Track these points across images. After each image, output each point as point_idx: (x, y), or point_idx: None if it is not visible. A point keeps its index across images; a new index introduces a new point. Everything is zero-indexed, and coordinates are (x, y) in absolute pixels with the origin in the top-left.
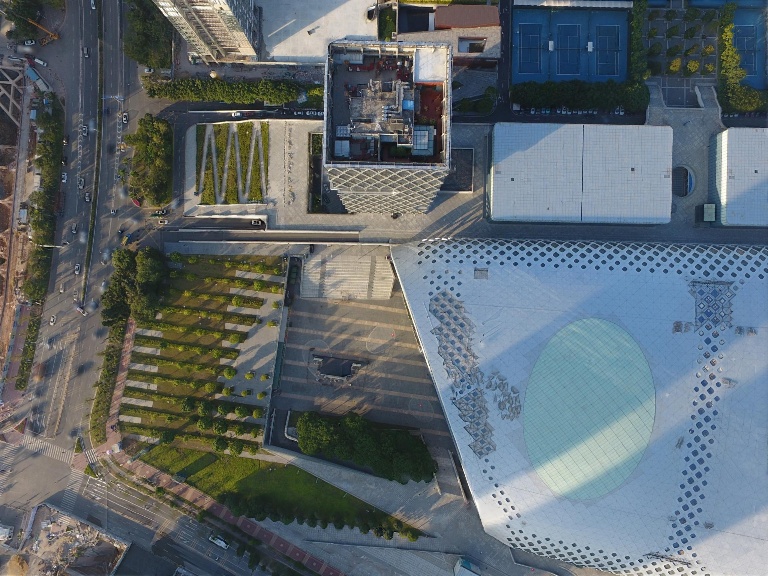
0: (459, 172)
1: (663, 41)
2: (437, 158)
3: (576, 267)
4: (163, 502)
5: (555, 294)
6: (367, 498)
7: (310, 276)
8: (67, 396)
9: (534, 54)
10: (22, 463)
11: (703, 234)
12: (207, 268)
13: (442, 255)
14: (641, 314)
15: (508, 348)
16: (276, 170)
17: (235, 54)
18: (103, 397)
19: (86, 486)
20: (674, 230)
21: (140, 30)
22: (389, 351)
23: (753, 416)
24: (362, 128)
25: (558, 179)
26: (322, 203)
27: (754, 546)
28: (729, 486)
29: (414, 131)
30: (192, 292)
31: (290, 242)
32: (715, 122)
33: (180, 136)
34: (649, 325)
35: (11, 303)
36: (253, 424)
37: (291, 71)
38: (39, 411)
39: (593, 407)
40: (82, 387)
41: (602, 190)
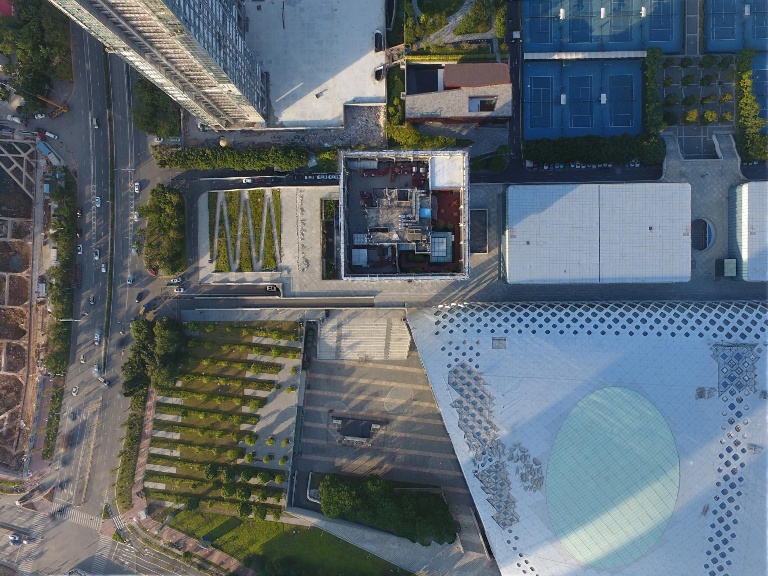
0: (473, 234)
1: (678, 89)
2: (456, 266)
3: (595, 333)
4: (190, 566)
5: (575, 363)
6: (391, 558)
7: (326, 339)
8: (92, 464)
9: (546, 108)
10: (52, 530)
11: (724, 287)
12: (224, 335)
13: (459, 324)
14: (663, 381)
15: (529, 420)
16: (289, 237)
17: (244, 121)
18: (128, 465)
19: (115, 551)
20: (694, 284)
21: (148, 101)
22: (408, 410)
23: None
24: (379, 237)
25: (574, 241)
26: (336, 267)
27: None
28: (756, 552)
29: (432, 238)
30: (210, 359)
31: (306, 308)
32: (734, 173)
33: (192, 204)
34: (671, 392)
35: (34, 375)
36: (275, 488)
37: (300, 134)
38: (66, 480)
39: (616, 477)
40: (107, 455)
41: (620, 250)
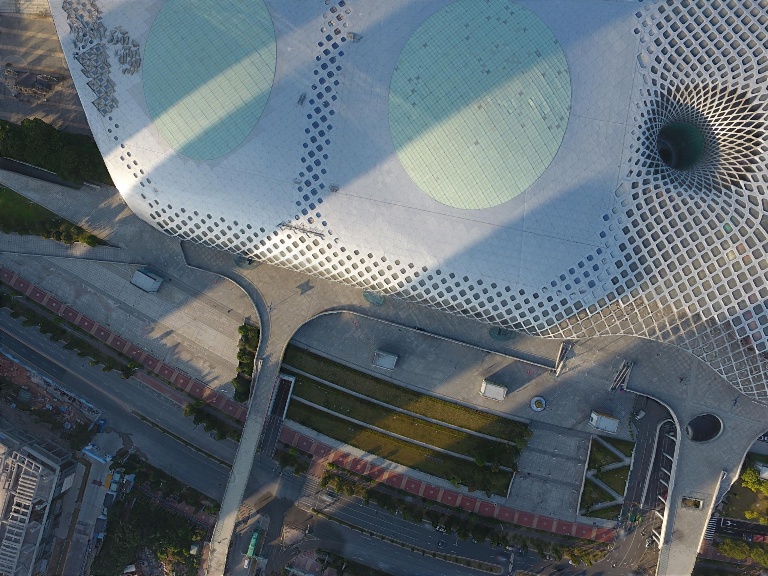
0: None
1: None
2: None
3: None
4: None
5: None
6: (54, 208)
7: None
8: None
9: None
10: None
11: None
12: None
13: None
14: None
15: (131, 3)
16: None
17: None
18: None
19: None
20: None
21: None
22: None
23: (376, 70)
24: None
25: None
26: None
27: (381, 211)
28: (352, 145)
29: None
30: None
31: None
32: None
33: None
34: None
35: None
36: None
37: None
38: None
39: (211, 59)
40: None
41: None
